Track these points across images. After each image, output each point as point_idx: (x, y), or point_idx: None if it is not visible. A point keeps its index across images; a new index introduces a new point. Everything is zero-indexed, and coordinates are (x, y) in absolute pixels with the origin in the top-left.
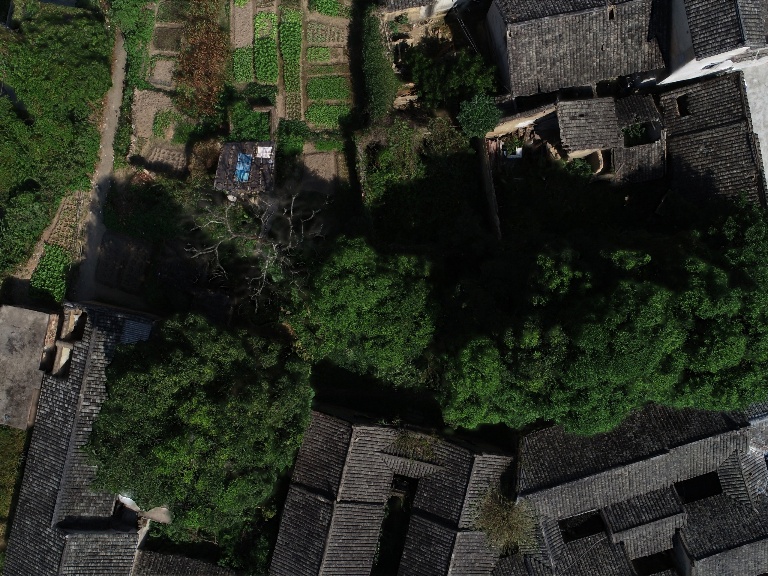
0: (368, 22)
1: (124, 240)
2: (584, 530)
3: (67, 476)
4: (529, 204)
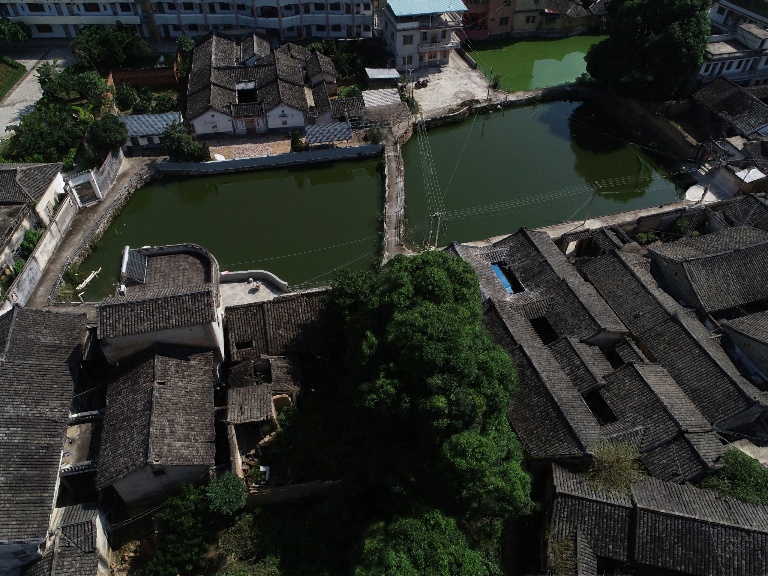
0: None
1: None
2: (604, 415)
3: None
4: (314, 461)
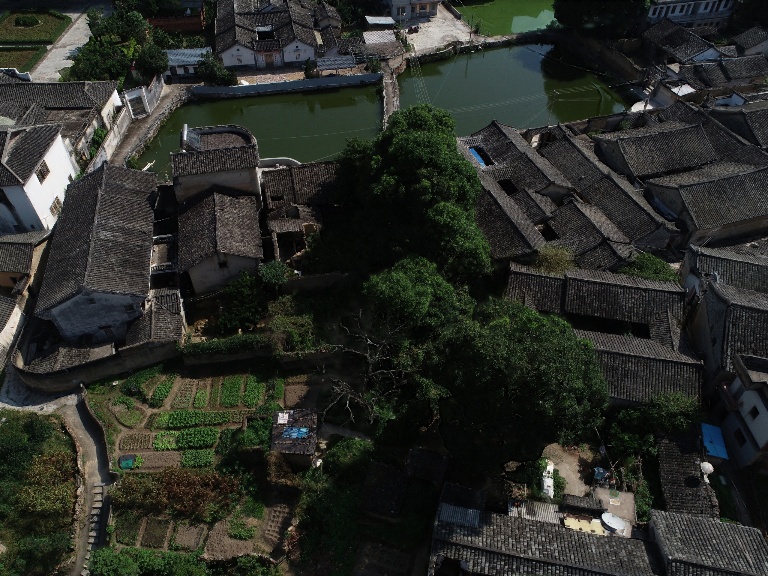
0: (188, 348)
1: (358, 572)
2: None
3: (610, 571)
4: (334, 269)
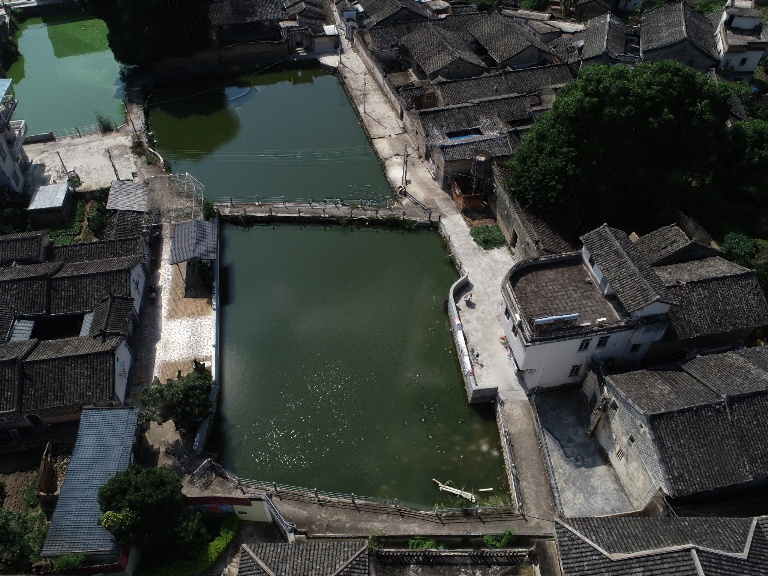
0: None
1: None
2: None
3: None
4: None
